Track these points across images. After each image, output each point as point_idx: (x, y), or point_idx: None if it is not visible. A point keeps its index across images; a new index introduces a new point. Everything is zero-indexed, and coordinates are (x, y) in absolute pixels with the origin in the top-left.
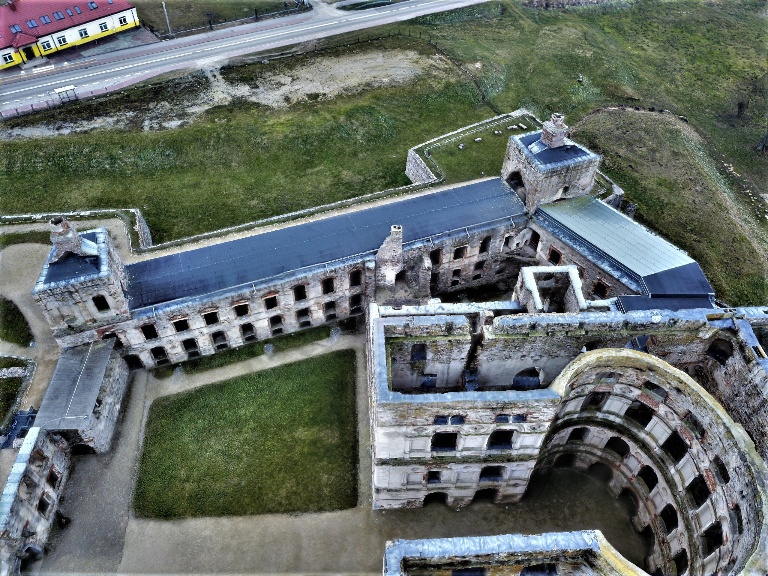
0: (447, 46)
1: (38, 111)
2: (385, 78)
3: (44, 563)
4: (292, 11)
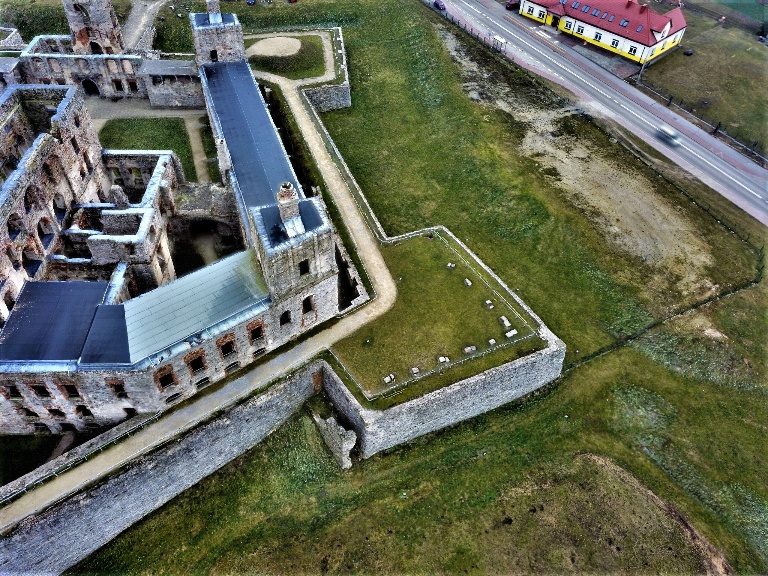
0: (755, 301)
1: (479, 40)
2: (619, 229)
3: (96, 98)
4: (760, 158)
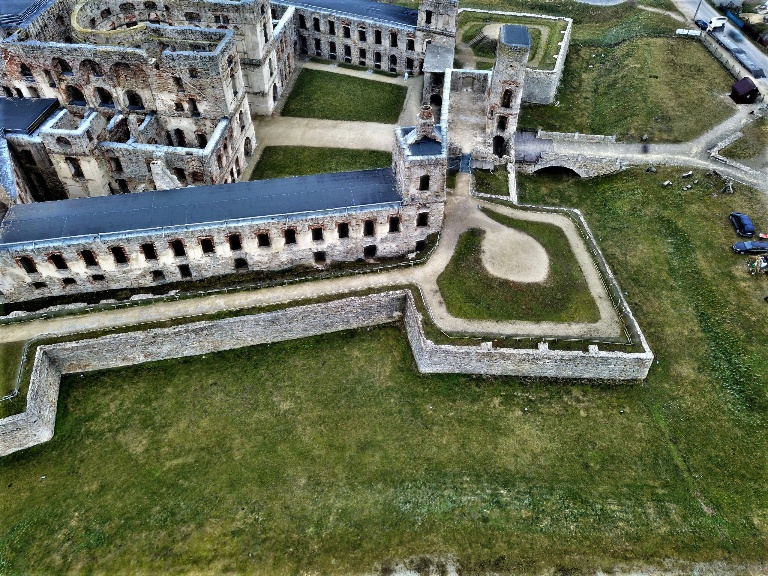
0: None
1: None
2: None
3: None
4: None
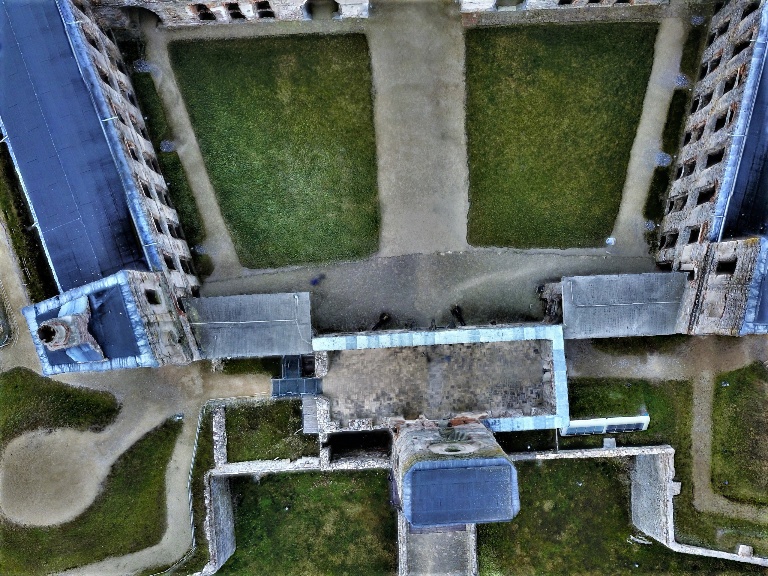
0: None
1: None
2: None
3: (423, 325)
4: None
